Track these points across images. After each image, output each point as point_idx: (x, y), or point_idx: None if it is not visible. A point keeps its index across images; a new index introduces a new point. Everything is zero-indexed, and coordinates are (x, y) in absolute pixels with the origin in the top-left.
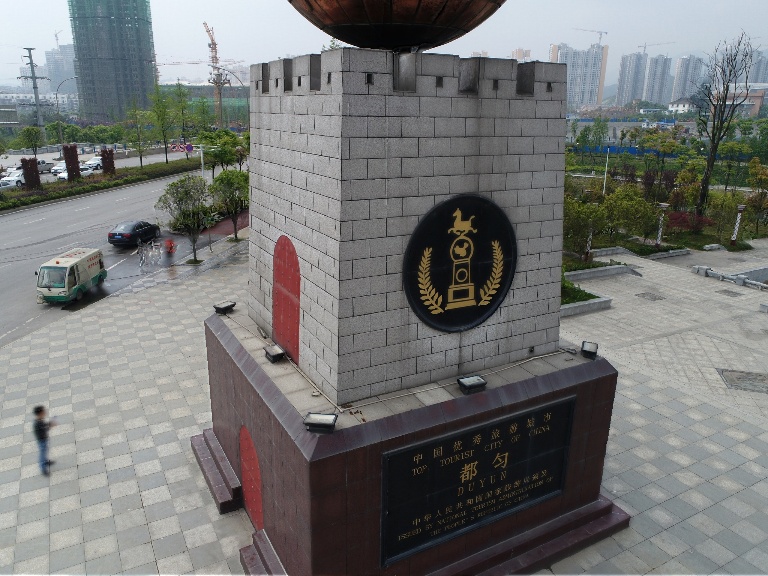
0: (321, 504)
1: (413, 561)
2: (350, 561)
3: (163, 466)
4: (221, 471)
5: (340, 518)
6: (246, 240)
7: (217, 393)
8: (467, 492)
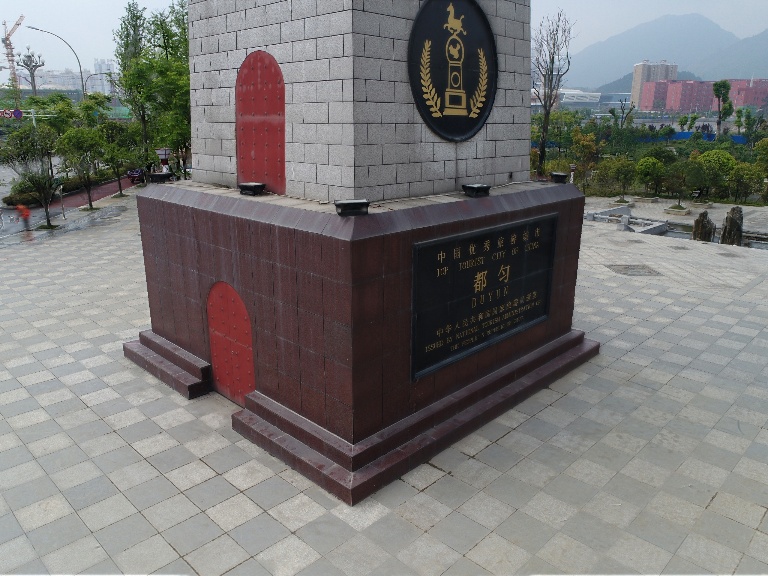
0: (361, 296)
1: (437, 378)
2: (385, 371)
3: (96, 374)
4: (178, 360)
5: (377, 316)
6: (104, 208)
7: (162, 274)
8: (479, 305)
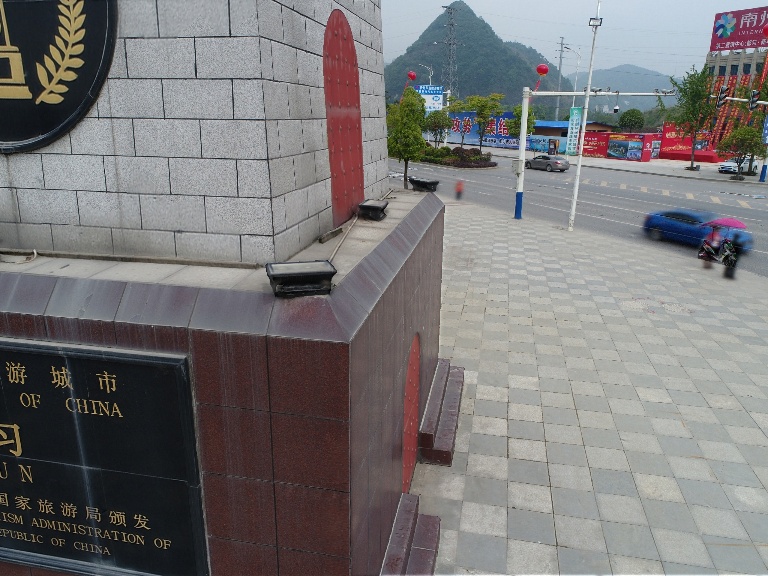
0: None
1: None
2: None
3: None
4: None
5: None
6: None
7: None
8: None
